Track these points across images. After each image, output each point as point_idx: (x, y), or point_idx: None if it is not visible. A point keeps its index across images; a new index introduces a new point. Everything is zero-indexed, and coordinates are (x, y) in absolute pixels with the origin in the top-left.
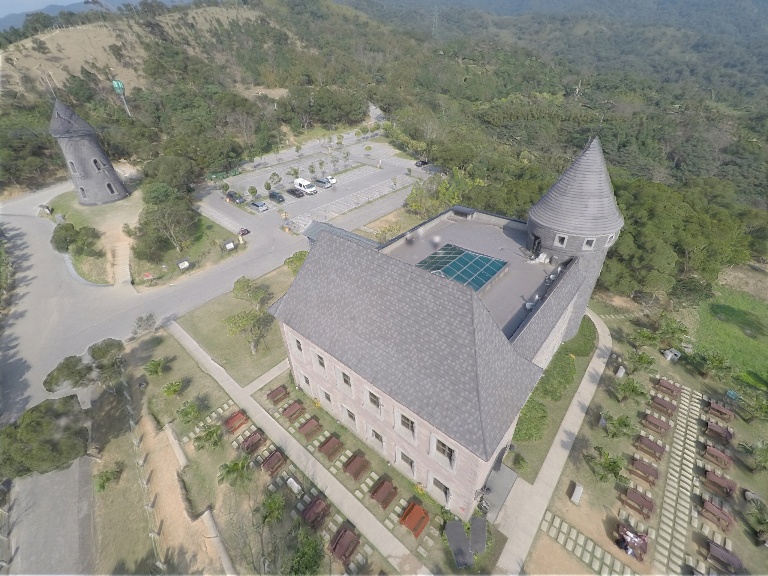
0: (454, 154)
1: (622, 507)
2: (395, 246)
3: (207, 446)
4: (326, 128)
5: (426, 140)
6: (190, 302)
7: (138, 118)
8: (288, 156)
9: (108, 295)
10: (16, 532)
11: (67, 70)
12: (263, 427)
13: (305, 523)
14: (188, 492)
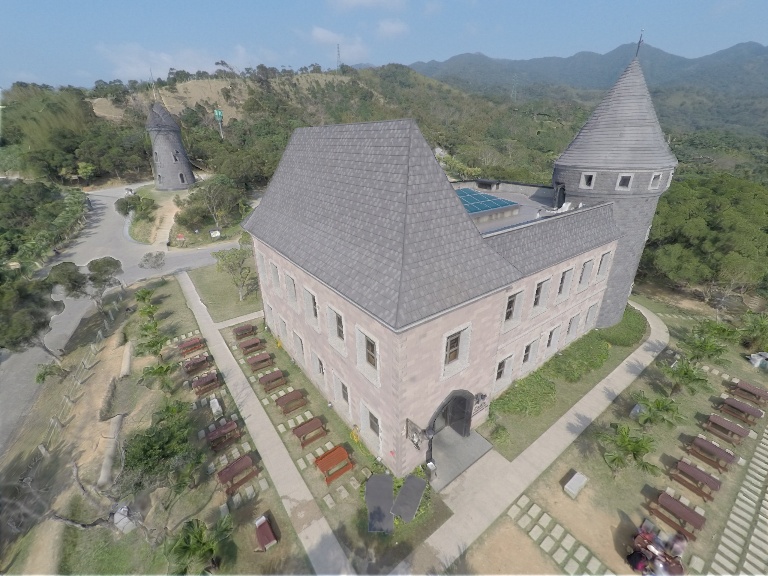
0: (507, 173)
1: (649, 517)
2: None
3: (147, 353)
4: None
5: (482, 166)
6: (207, 260)
7: (227, 139)
8: None
9: (144, 250)
10: None
11: (185, 104)
12: (215, 355)
13: (208, 443)
14: (114, 398)
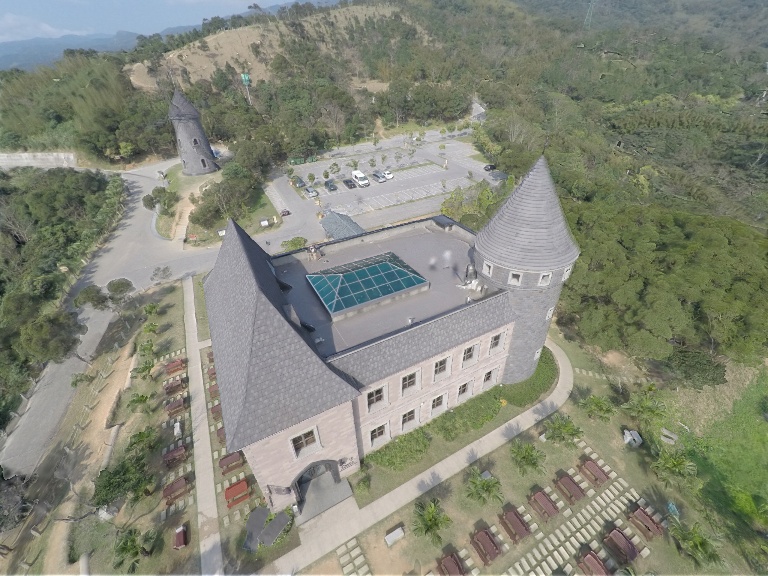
0: (519, 161)
1: (434, 570)
2: (347, 245)
3: (139, 377)
4: (419, 124)
5: (504, 143)
6: (211, 264)
7: (253, 106)
8: (367, 148)
9: (164, 247)
10: (34, 397)
11: (216, 64)
12: (191, 377)
13: None
14: (118, 407)
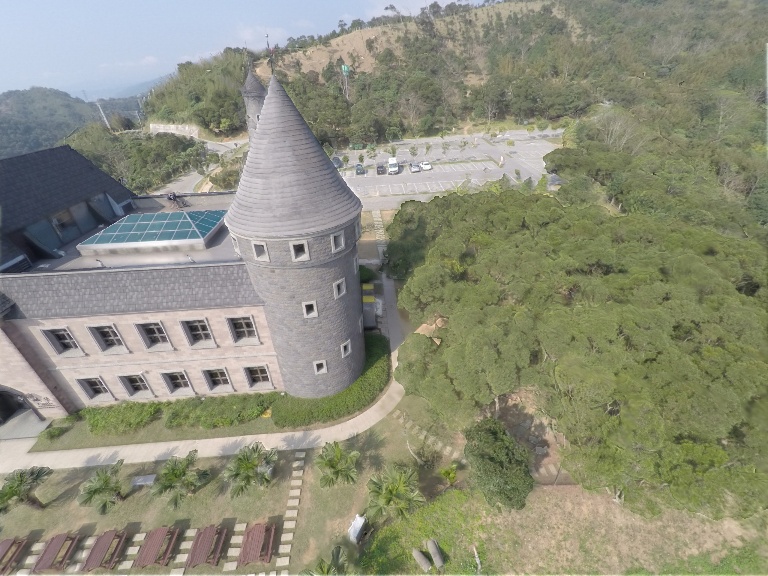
0: (574, 160)
1: None
2: (218, 201)
3: None
4: None
5: None
6: None
7: (344, 95)
8: (437, 141)
9: None
10: None
11: (331, 58)
12: None
13: None
14: None
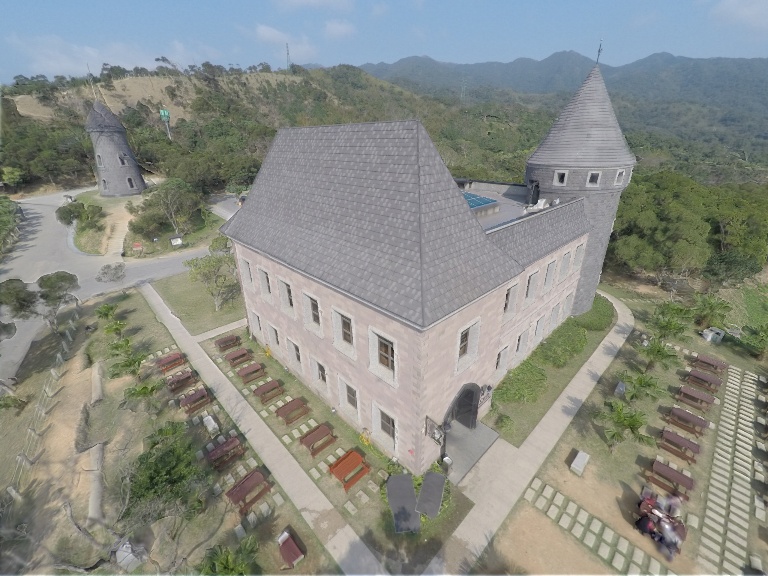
0: (467, 172)
1: (646, 484)
2: None
3: (124, 374)
4: None
5: None
6: (171, 270)
7: (176, 141)
8: None
9: (95, 262)
10: None
11: (125, 103)
12: (199, 369)
13: (209, 463)
14: (89, 426)
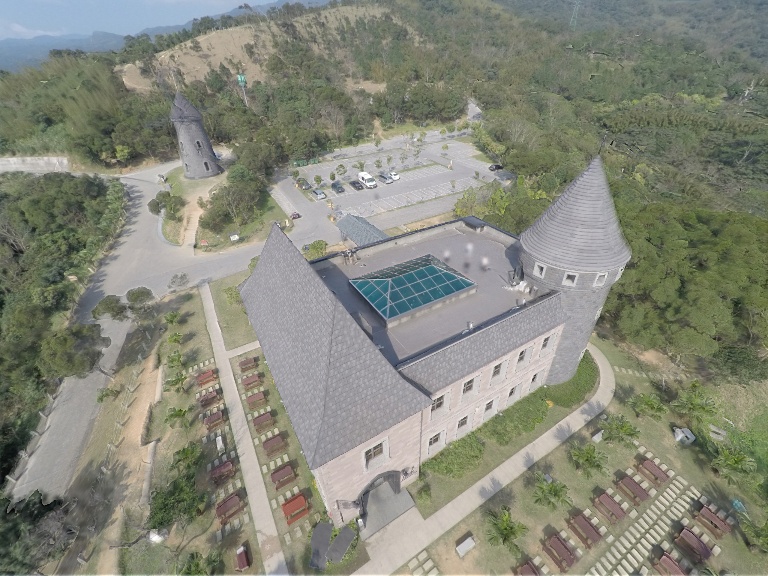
0: (527, 161)
1: None
2: (381, 248)
3: (172, 390)
4: (417, 124)
5: (507, 143)
6: (226, 270)
7: None
8: (369, 149)
9: (174, 253)
10: (53, 415)
11: (210, 65)
12: (224, 388)
13: None
14: (151, 422)
